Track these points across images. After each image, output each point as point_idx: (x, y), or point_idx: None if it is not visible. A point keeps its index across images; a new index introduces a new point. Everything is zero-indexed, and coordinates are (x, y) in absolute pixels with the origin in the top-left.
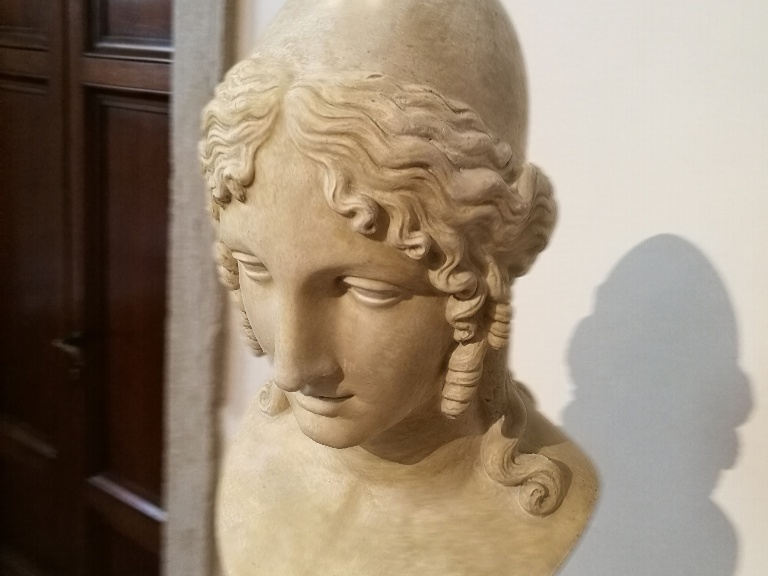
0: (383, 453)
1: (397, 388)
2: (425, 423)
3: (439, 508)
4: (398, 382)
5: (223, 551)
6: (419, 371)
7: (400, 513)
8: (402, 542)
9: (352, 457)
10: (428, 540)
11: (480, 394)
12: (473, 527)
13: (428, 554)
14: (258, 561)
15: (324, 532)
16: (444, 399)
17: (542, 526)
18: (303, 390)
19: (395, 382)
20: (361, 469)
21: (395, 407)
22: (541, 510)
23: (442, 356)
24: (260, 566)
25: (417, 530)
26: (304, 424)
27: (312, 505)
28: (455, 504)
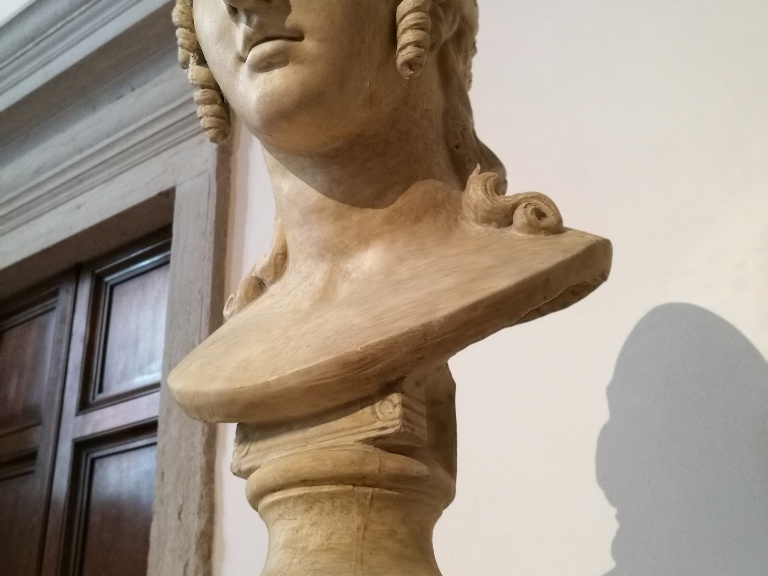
0: (352, 195)
1: (346, 20)
2: (391, 145)
3: (426, 256)
4: (345, 9)
5: (173, 381)
6: (365, 4)
7: (382, 271)
8: (387, 284)
9: (321, 230)
10: (417, 274)
11: (448, 142)
12: (467, 255)
13: (418, 279)
14: (215, 360)
15: (295, 318)
16: (398, 55)
17: (546, 239)
18: (251, 25)
19: (342, 9)
20: (333, 242)
21: (348, 55)
22: (540, 223)
23: (388, 10)
24: (217, 360)
25: (403, 274)
26: (257, 93)
27: (281, 314)
28: (443, 249)
